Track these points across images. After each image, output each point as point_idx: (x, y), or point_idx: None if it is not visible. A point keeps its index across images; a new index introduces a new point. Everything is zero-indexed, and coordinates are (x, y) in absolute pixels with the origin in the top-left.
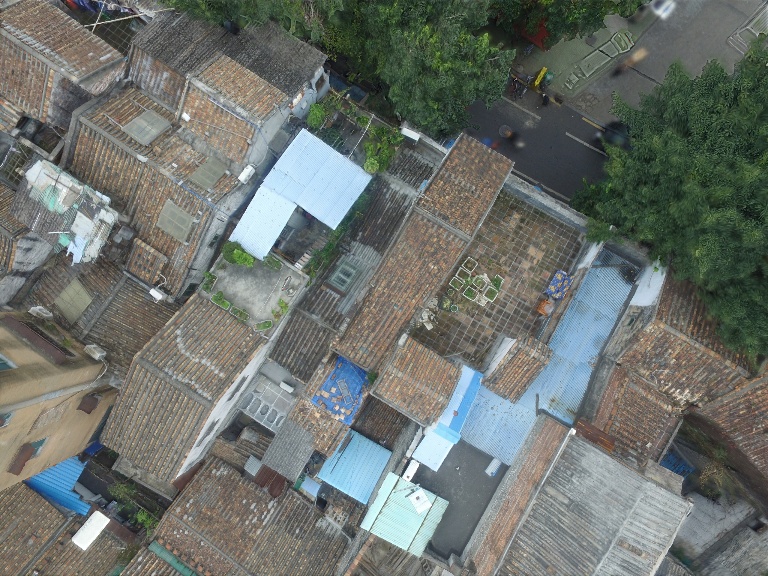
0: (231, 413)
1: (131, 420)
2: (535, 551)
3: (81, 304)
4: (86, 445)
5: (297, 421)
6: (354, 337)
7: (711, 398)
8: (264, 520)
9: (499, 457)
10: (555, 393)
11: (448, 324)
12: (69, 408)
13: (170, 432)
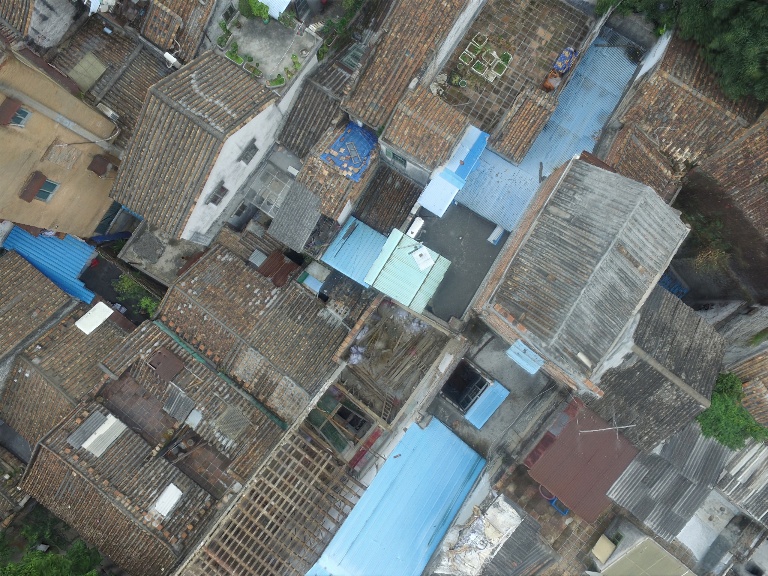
0: (238, 200)
1: (142, 165)
2: (536, 264)
3: (95, 73)
4: (93, 233)
5: (305, 182)
6: (365, 92)
7: (710, 153)
8: (267, 304)
9: (501, 224)
10: (558, 163)
11: (456, 99)
12: (80, 160)
13: (181, 174)
